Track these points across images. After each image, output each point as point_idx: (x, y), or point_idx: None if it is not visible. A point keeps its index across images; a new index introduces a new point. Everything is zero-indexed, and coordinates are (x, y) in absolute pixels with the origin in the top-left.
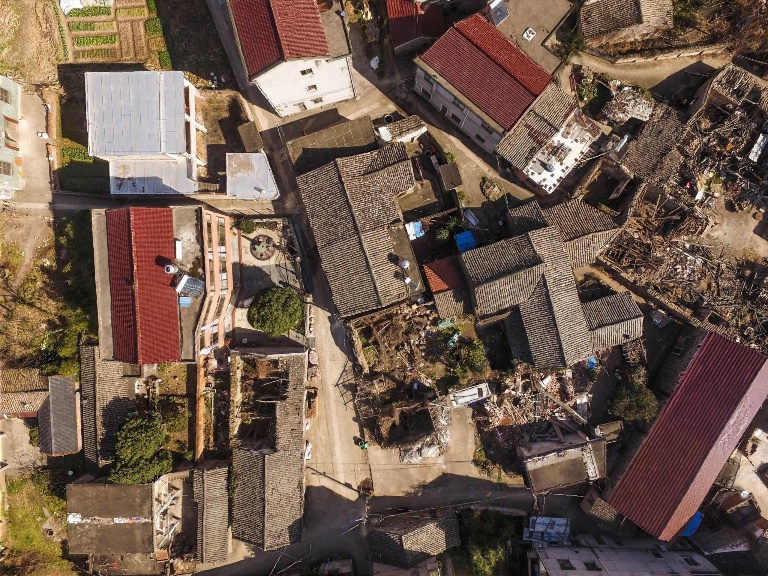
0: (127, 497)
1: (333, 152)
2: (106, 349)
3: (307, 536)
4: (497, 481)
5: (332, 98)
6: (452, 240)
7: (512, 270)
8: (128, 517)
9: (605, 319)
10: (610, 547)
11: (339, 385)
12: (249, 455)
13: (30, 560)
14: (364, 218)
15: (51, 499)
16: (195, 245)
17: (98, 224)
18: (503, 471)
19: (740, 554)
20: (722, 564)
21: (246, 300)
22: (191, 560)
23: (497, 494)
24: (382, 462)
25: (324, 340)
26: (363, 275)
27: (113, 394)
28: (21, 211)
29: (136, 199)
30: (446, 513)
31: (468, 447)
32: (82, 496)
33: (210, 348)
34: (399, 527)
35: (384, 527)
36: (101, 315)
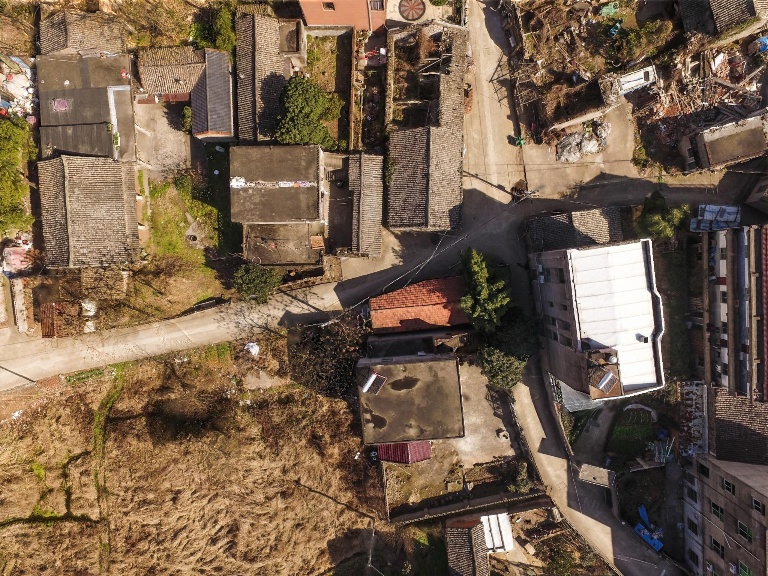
0: (292, 160)
1: None
2: None
3: None
4: (657, 181)
5: None
6: None
7: None
8: (293, 181)
9: None
10: None
11: (493, 81)
12: (410, 134)
13: (175, 263)
14: None
15: (194, 204)
16: None
17: None
18: (664, 170)
19: None
20: None
21: None
22: (345, 253)
23: None
24: (537, 162)
25: (478, 33)
26: None
27: (270, 69)
28: None
29: None
30: None
31: (627, 145)
32: (246, 159)
33: None
34: None
35: None
36: None
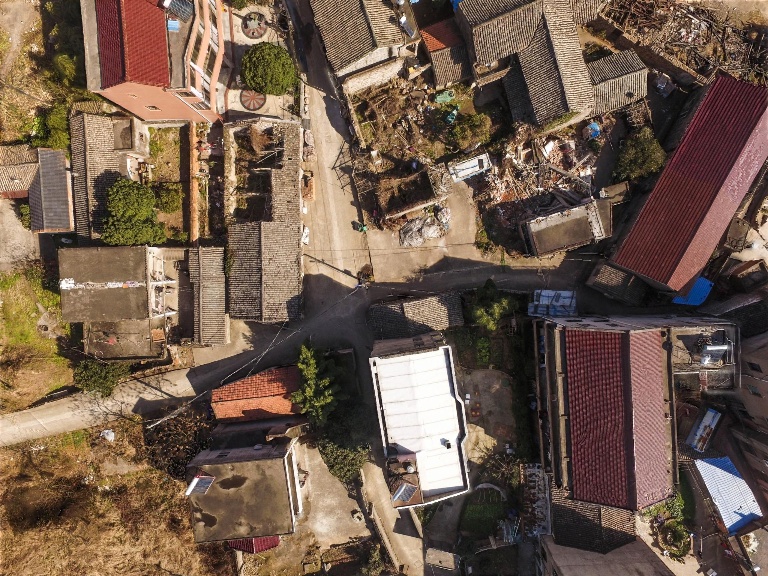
0: (120, 260)
1: None
2: (93, 80)
3: (307, 326)
4: (500, 263)
5: None
6: (448, 5)
7: (511, 9)
8: (122, 281)
9: (608, 75)
10: (618, 316)
11: (336, 168)
12: (245, 227)
13: (25, 354)
14: None
15: (45, 294)
16: None
17: None
18: (506, 253)
19: (752, 306)
20: (734, 319)
21: (238, 75)
22: (188, 343)
23: (500, 277)
24: (382, 246)
25: (319, 121)
26: (357, 19)
27: (104, 167)
28: None
29: None
30: (448, 292)
31: (470, 229)
32: (74, 261)
33: (201, 98)
34: (400, 302)
35: None
36: (87, 43)
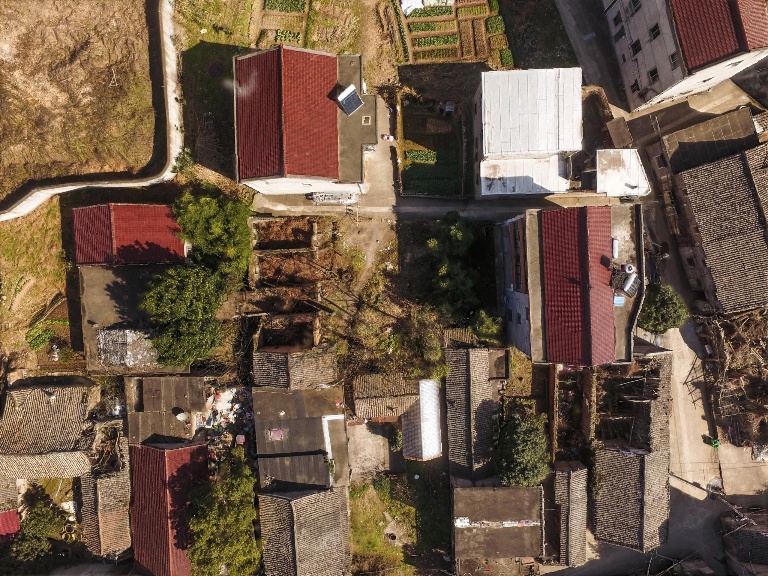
0: (516, 500)
1: (710, 145)
2: (535, 351)
3: None
4: None
5: (694, 91)
6: None
7: None
8: (517, 520)
9: None
10: None
11: (688, 383)
12: (619, 456)
13: (377, 565)
14: (767, 212)
15: (393, 504)
16: (629, 243)
17: (530, 225)
18: None
19: None
20: None
21: None
22: (551, 563)
23: None
24: (733, 460)
25: (672, 338)
26: (764, 270)
27: (482, 397)
28: (365, 215)
29: (485, 199)
30: None
31: None
32: (470, 500)
33: None
34: None
35: (750, 526)
36: (531, 317)
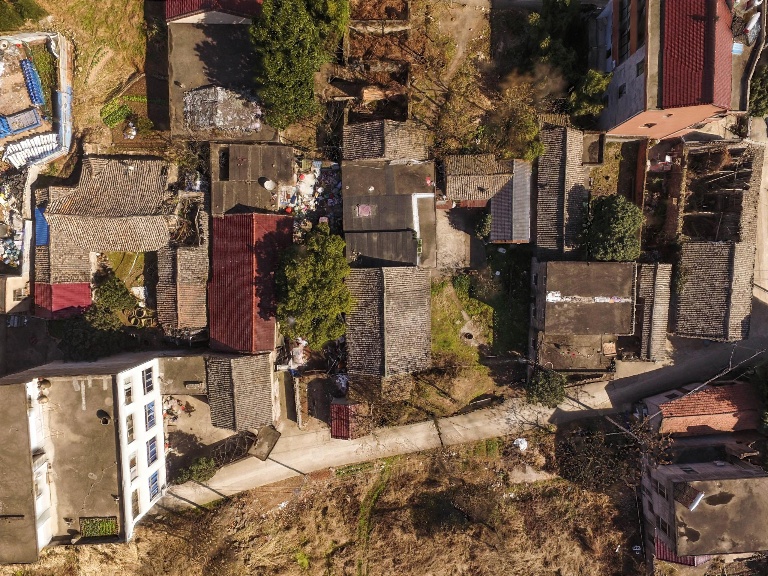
0: (609, 276)
1: None
2: (650, 98)
3: None
4: None
5: None
6: None
7: None
8: (608, 296)
9: None
10: None
11: None
12: (708, 246)
13: (453, 361)
14: None
15: (471, 302)
16: None
17: None
18: None
19: None
20: None
21: None
22: (631, 358)
23: None
24: None
25: None
26: None
27: (574, 180)
28: (459, 0)
29: None
30: None
31: None
32: (563, 274)
33: None
34: None
35: None
36: (649, 62)
